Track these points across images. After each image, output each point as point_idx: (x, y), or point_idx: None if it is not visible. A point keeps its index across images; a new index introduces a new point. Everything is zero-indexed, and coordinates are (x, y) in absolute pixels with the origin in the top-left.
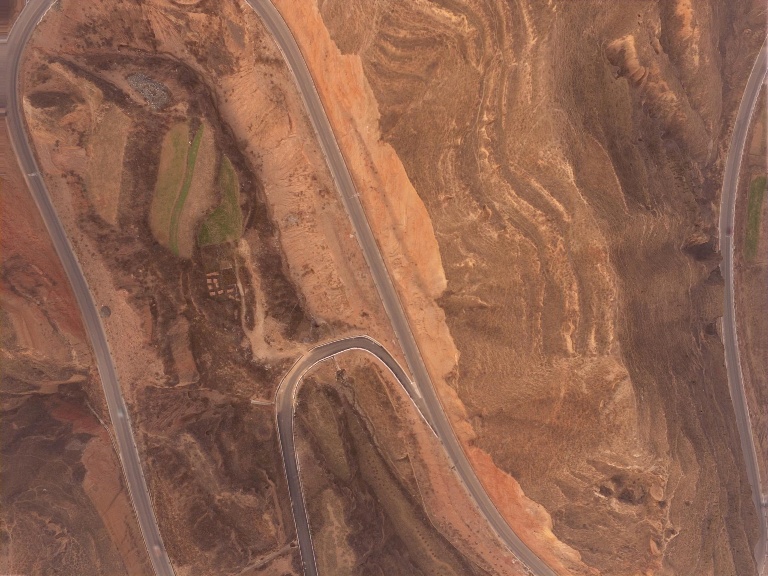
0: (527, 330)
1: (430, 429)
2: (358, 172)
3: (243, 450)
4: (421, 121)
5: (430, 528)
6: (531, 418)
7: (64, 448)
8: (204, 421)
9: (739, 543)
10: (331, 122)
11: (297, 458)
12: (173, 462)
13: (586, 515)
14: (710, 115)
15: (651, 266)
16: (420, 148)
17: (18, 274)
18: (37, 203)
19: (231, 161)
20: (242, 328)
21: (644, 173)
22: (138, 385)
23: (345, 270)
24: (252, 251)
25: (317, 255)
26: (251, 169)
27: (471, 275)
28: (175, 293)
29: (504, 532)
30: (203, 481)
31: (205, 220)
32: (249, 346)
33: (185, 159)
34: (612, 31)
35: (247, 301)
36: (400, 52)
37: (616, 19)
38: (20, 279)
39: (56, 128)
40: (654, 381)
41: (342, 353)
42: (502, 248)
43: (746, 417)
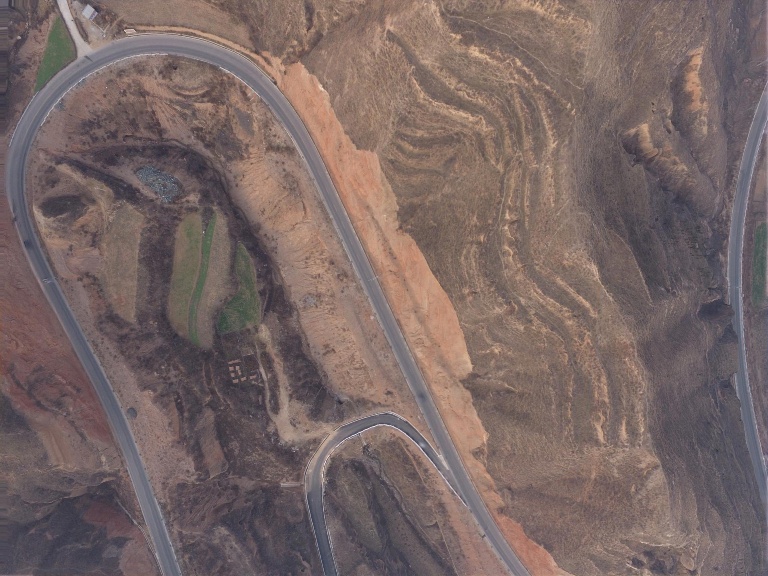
0: (557, 419)
1: (459, 499)
2: (376, 255)
3: (277, 535)
4: (440, 214)
5: None
6: (562, 495)
7: (101, 556)
8: (237, 512)
9: None
10: (346, 206)
11: (329, 536)
12: (209, 557)
13: None
14: (717, 173)
15: (673, 344)
16: (441, 241)
17: (42, 387)
18: (54, 308)
19: (246, 247)
20: (267, 412)
21: (663, 256)
22: (169, 484)
23: (367, 351)
24: (272, 336)
25: (338, 336)
26: (266, 251)
27: (497, 362)
28: (199, 386)
29: None
30: (240, 572)
31: (223, 308)
32: (275, 430)
33: (200, 249)
34: (627, 121)
35: (270, 386)
36: (418, 150)
37: (631, 109)
38: (45, 392)
39: (69, 233)
40: (683, 463)
41: (368, 430)
42: (528, 339)
43: (761, 460)
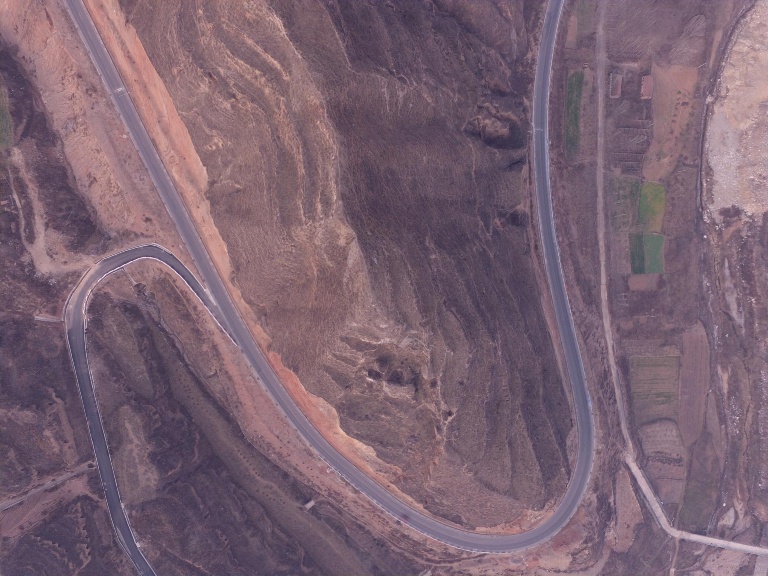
0: (267, 204)
1: (228, 337)
2: (124, 67)
3: (23, 367)
4: None
5: (251, 447)
6: (299, 306)
7: None
8: None
9: (543, 432)
10: (92, 15)
11: (91, 376)
12: None
13: (367, 405)
14: None
15: (406, 137)
16: (155, 23)
17: None
18: None
19: None
20: (22, 242)
21: (385, 36)
22: None
23: (121, 173)
24: (27, 160)
25: (95, 161)
26: (25, 76)
27: (222, 157)
28: None
29: (316, 441)
30: None
31: None
32: (31, 261)
33: None
34: None
35: (25, 213)
36: None
37: None
38: None
39: None
40: (396, 247)
41: (131, 263)
42: (240, 121)
43: (568, 314)
